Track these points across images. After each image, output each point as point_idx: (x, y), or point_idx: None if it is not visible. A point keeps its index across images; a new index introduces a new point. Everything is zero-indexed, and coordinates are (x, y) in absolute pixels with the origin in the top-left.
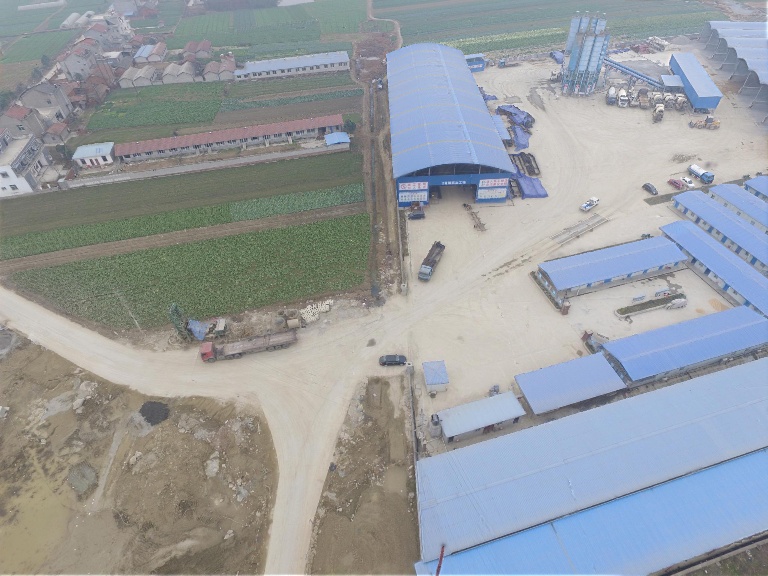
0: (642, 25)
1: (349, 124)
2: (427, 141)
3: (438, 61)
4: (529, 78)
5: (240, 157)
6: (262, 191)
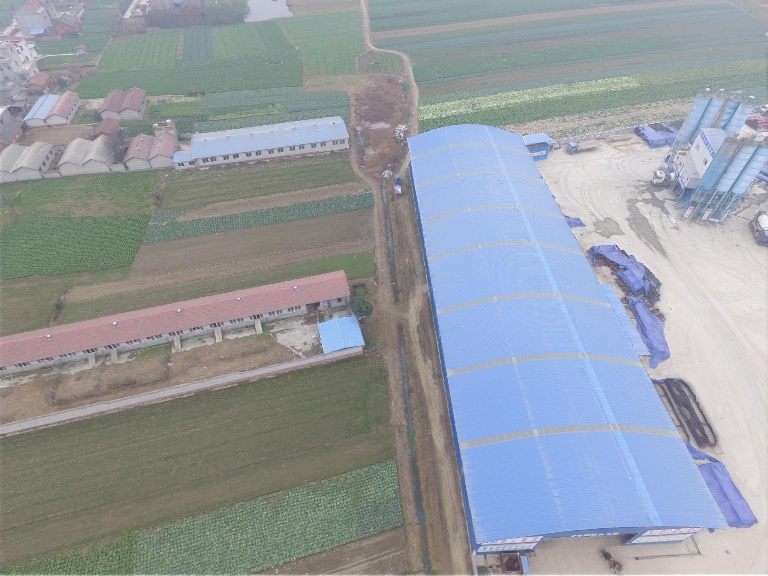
0: (738, 76)
1: (361, 309)
2: (531, 423)
3: (496, 169)
4: (618, 178)
5: (165, 389)
6: (202, 488)
